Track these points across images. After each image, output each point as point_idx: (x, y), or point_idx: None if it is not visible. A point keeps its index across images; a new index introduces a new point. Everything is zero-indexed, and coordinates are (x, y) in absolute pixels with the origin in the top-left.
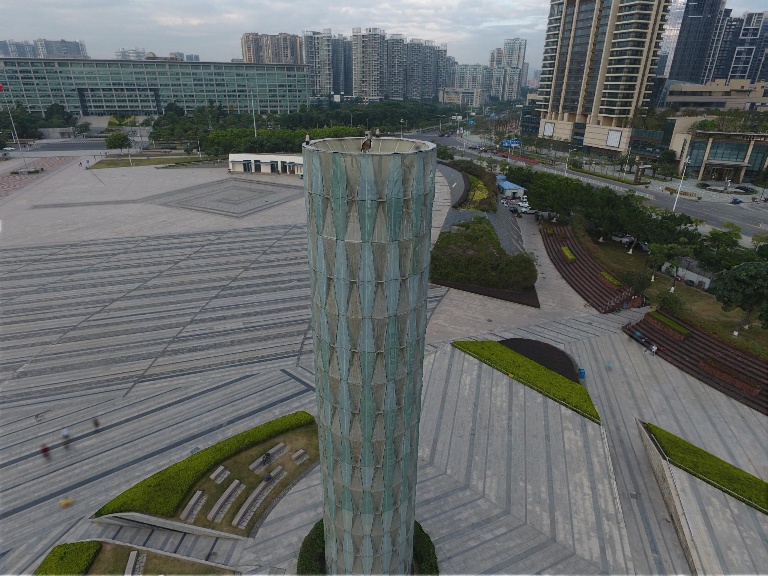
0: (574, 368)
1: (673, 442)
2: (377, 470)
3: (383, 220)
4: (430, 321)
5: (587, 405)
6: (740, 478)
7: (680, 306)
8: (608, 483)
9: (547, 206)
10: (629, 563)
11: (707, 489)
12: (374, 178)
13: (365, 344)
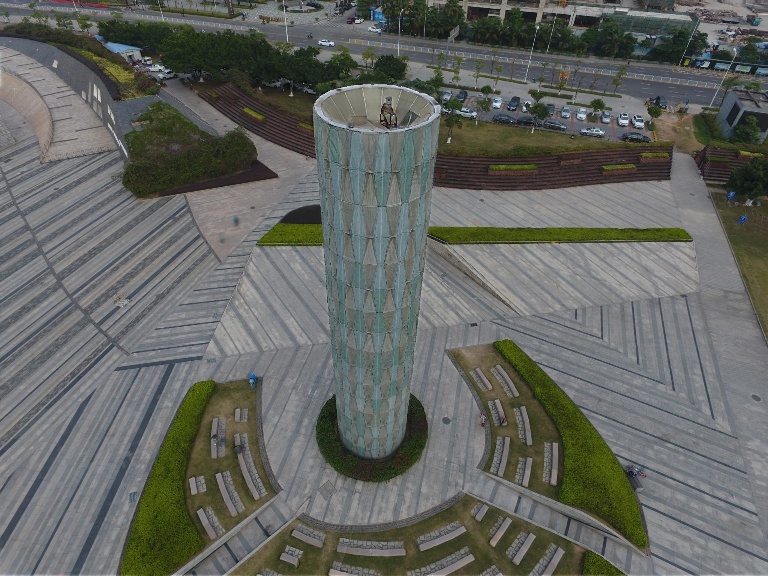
0: None
1: (438, 231)
2: None
3: (429, 172)
4: (204, 235)
5: None
6: (476, 232)
7: None
8: (432, 277)
9: (191, 67)
10: (472, 311)
11: (471, 248)
12: None
13: None
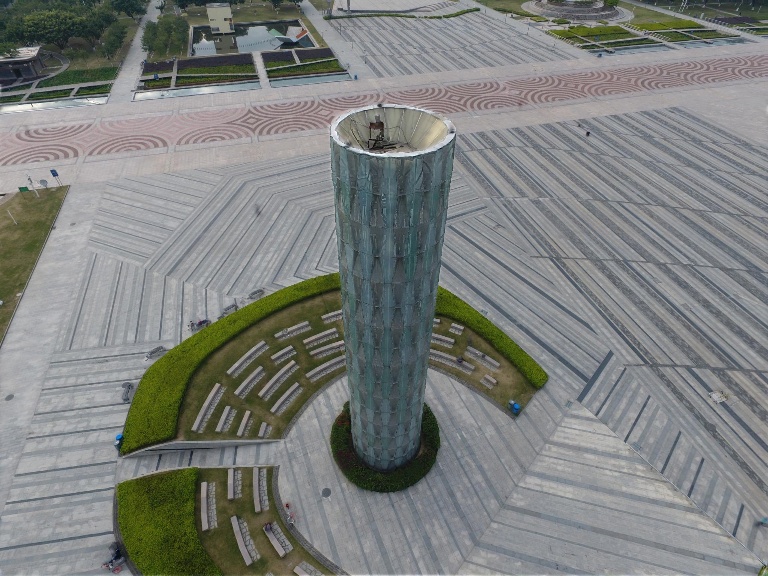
0: None
1: None
2: None
3: None
4: None
5: None
6: None
7: None
8: None
9: None
10: None
11: None
12: None
13: None
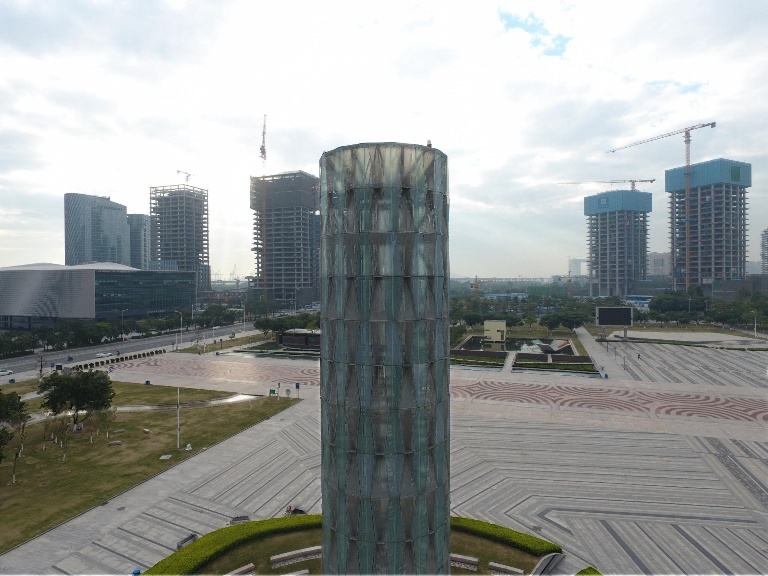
0: None
1: None
2: None
3: None
4: None
5: None
6: None
7: None
8: None
9: None
10: None
11: None
12: None
13: None
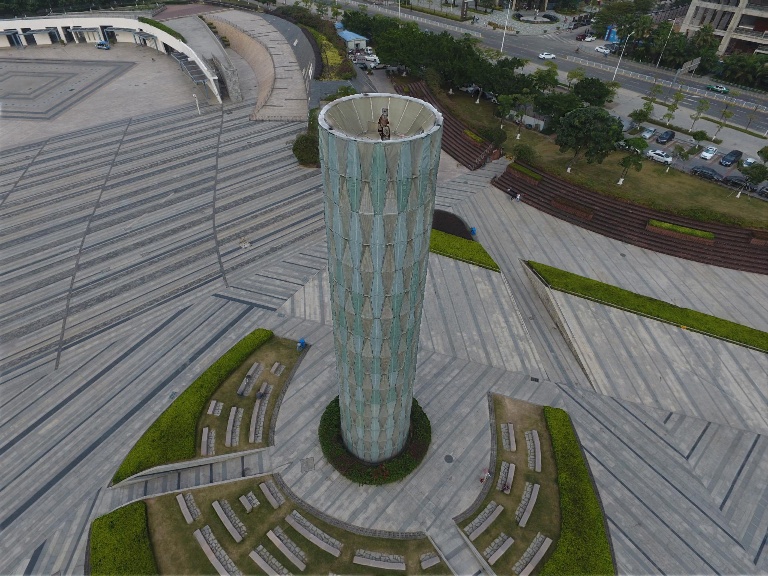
0: (466, 227)
1: (548, 271)
2: (399, 371)
3: (414, 191)
4: None
5: (487, 259)
6: (592, 286)
7: (532, 155)
8: (515, 315)
9: (397, 61)
10: (540, 365)
11: (576, 300)
12: (411, 160)
13: (395, 288)
